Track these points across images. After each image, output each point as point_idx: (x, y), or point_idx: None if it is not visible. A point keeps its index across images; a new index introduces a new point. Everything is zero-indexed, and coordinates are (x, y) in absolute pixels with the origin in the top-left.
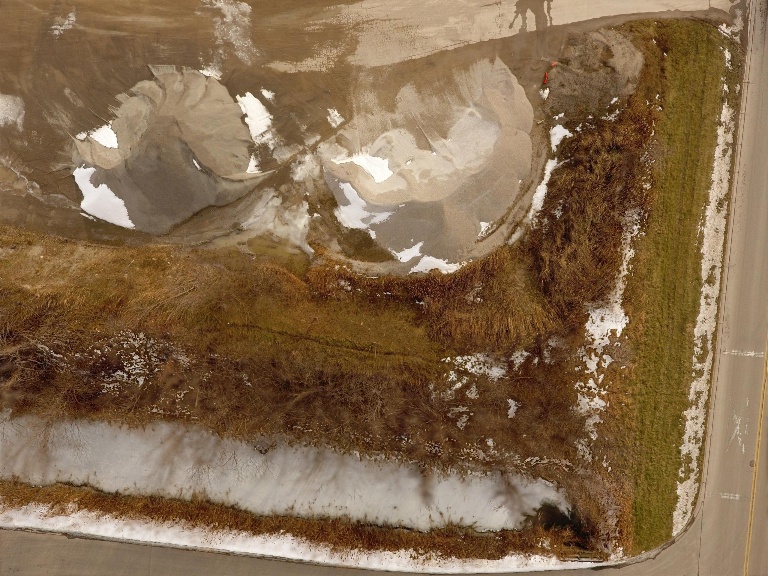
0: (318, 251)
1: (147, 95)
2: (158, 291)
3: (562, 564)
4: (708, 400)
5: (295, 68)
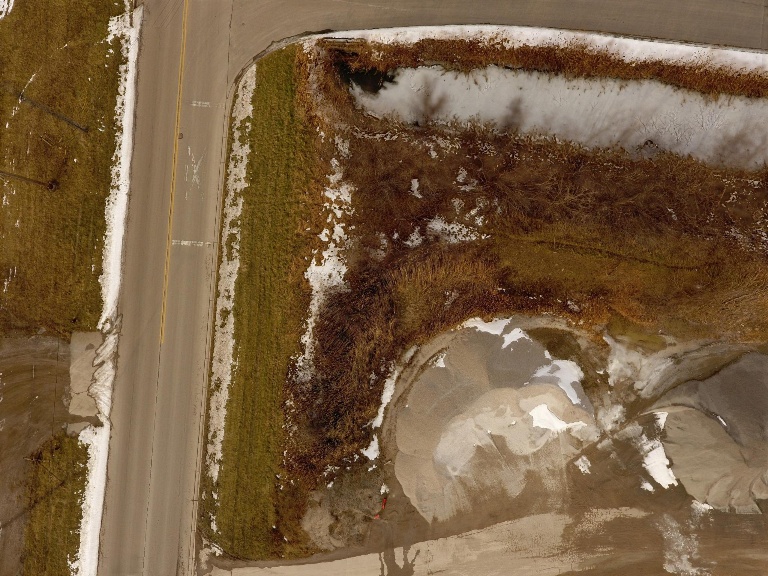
0: (600, 338)
1: (766, 486)
2: (764, 301)
3: (363, 36)
4: (225, 198)
5: (622, 512)
